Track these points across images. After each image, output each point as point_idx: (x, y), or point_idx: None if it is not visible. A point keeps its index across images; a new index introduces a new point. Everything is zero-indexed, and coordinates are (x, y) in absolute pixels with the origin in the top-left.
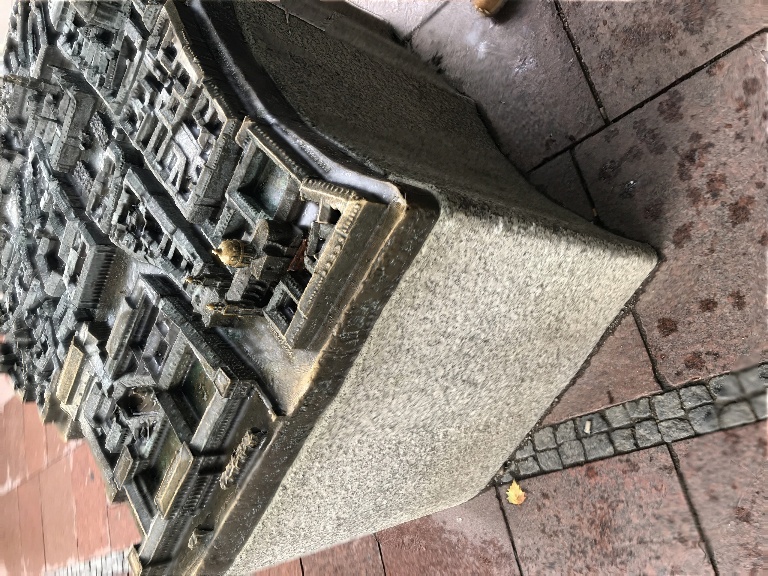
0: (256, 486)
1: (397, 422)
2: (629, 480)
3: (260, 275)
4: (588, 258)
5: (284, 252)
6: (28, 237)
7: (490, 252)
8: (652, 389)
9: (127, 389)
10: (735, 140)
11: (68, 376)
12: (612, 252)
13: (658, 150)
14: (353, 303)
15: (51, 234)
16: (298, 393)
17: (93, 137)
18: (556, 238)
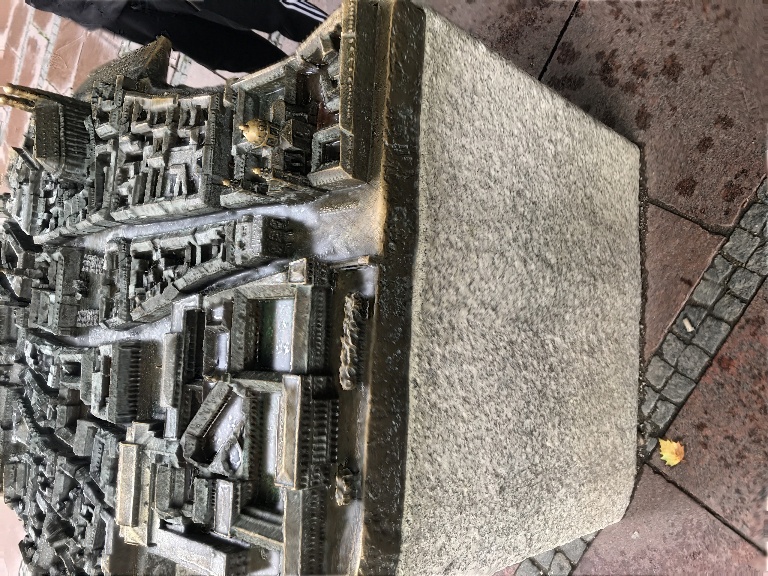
0: (383, 377)
1: (496, 302)
2: (764, 337)
3: (292, 141)
4: (576, 118)
5: (306, 120)
6: (41, 435)
7: (487, 75)
8: (716, 243)
9: (198, 440)
10: (630, 34)
11: (126, 488)
12: (594, 120)
13: (579, 85)
14: (389, 105)
15: (67, 400)
16: (379, 224)
17: (87, 283)
18: (537, 81)
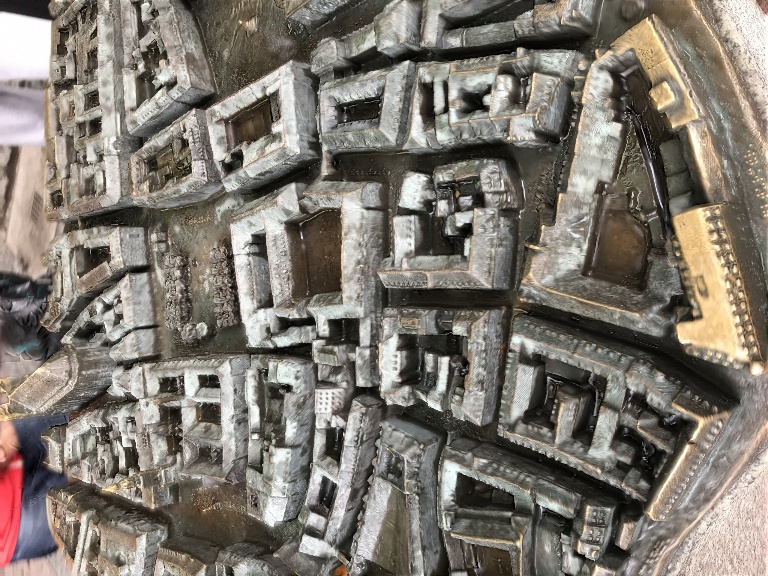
0: None
1: None
2: None
3: None
4: None
5: None
6: None
7: None
8: None
9: None
10: None
11: None
12: None
13: None
14: None
15: None
16: None
17: None
18: None
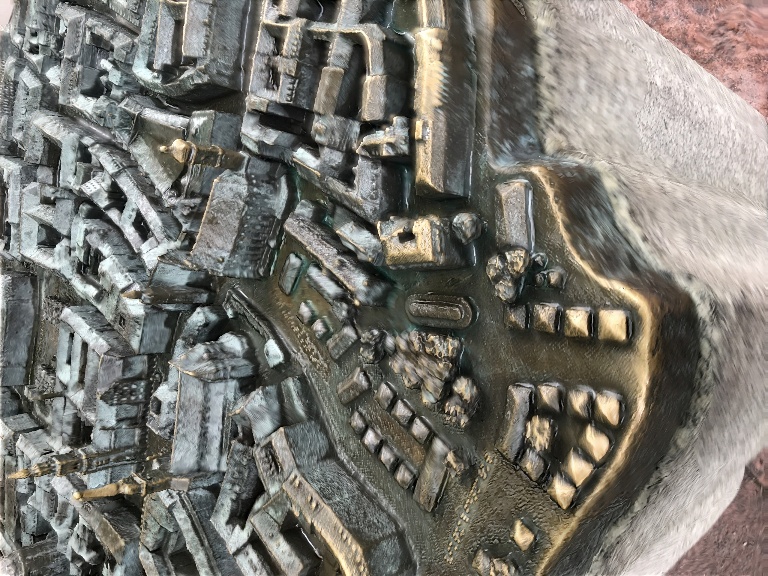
0: None
1: None
2: None
3: None
4: None
5: None
6: None
7: None
8: None
9: None
10: None
11: None
12: None
13: None
14: None
15: None
16: None
17: None
18: None
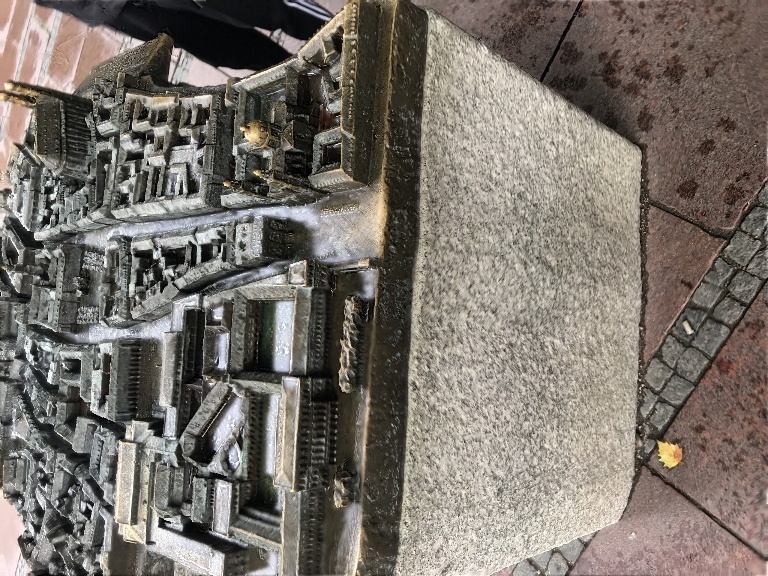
0: (382, 380)
1: (496, 305)
2: (763, 341)
3: (293, 142)
4: (578, 120)
5: (307, 122)
6: (41, 431)
7: (489, 77)
8: (717, 246)
9: (197, 439)
10: (633, 35)
11: (125, 486)
12: (595, 121)
13: (582, 85)
14: (391, 107)
15: (66, 396)
16: (379, 227)
17: (88, 281)
18: (539, 83)
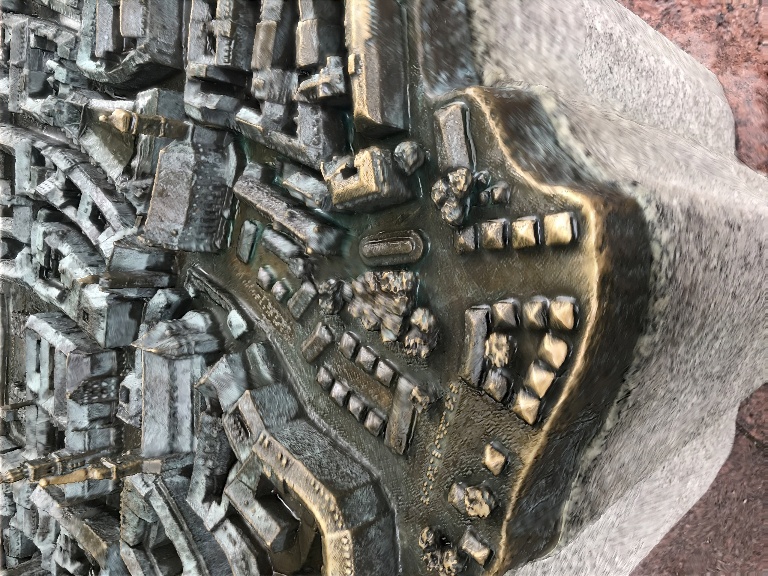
0: None
1: None
2: None
3: None
4: None
5: None
6: None
7: None
8: None
9: None
10: None
11: None
12: None
13: None
14: None
15: None
16: None
17: None
18: None
